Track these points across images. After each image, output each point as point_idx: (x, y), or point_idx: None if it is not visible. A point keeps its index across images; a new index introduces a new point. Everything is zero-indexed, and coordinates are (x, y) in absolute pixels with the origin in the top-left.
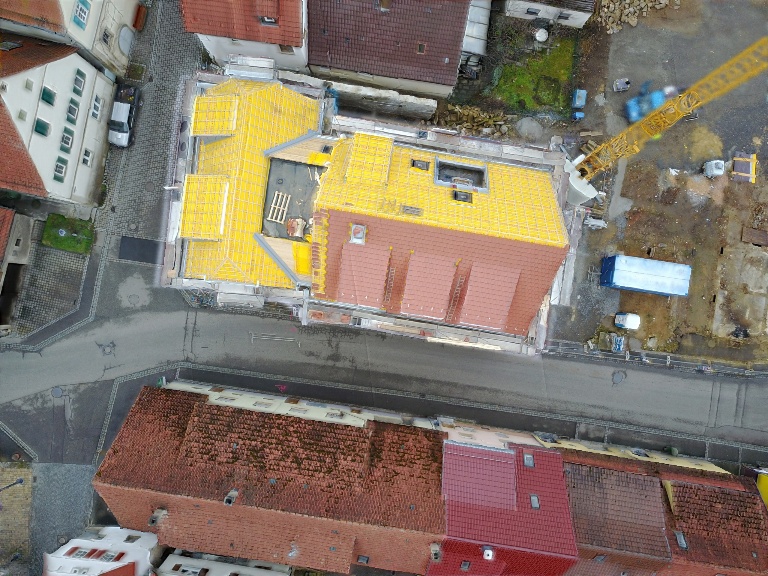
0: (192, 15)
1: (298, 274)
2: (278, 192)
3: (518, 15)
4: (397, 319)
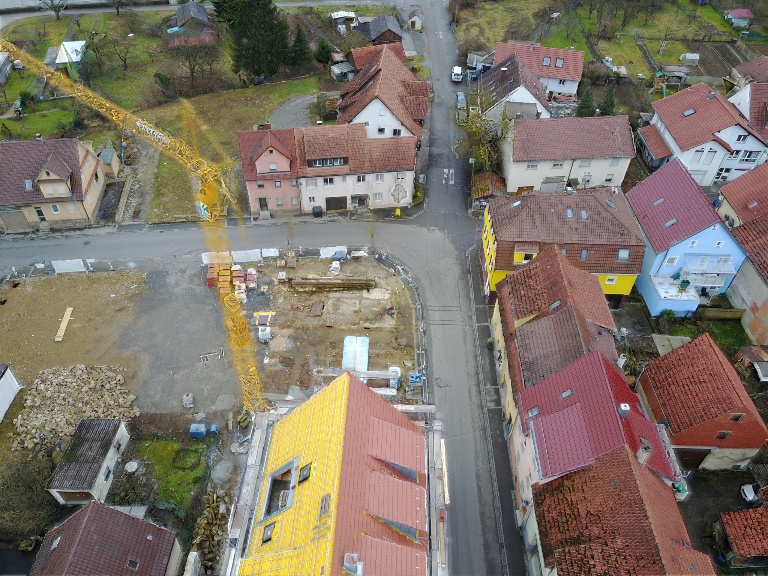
0: None
1: None
2: None
3: (105, 491)
4: (432, 548)
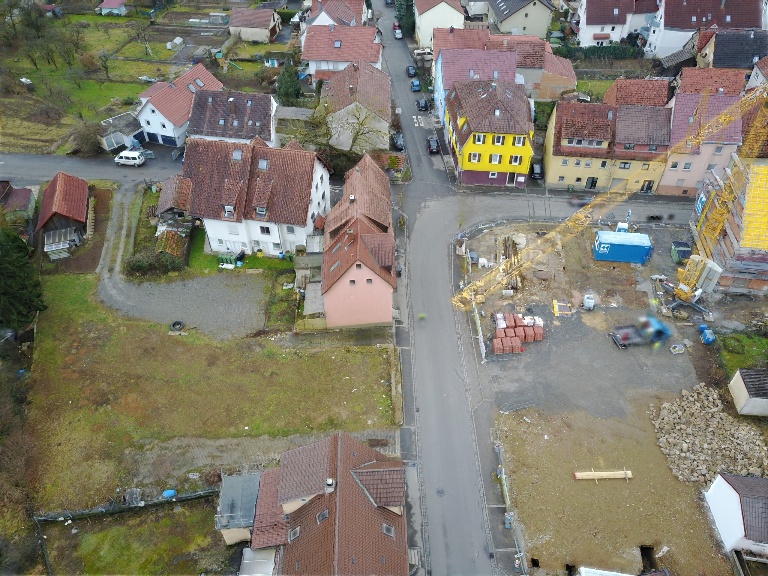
0: None
1: None
2: None
3: None
4: None
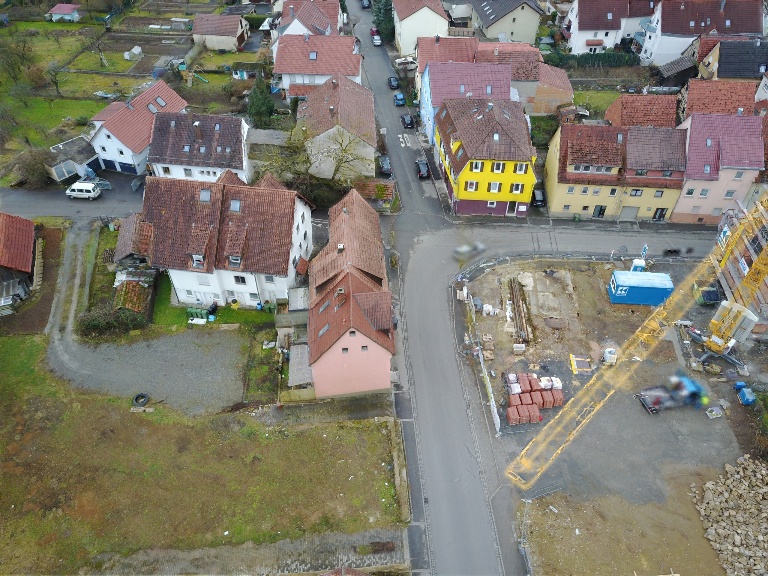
0: None
1: None
2: None
3: None
4: None
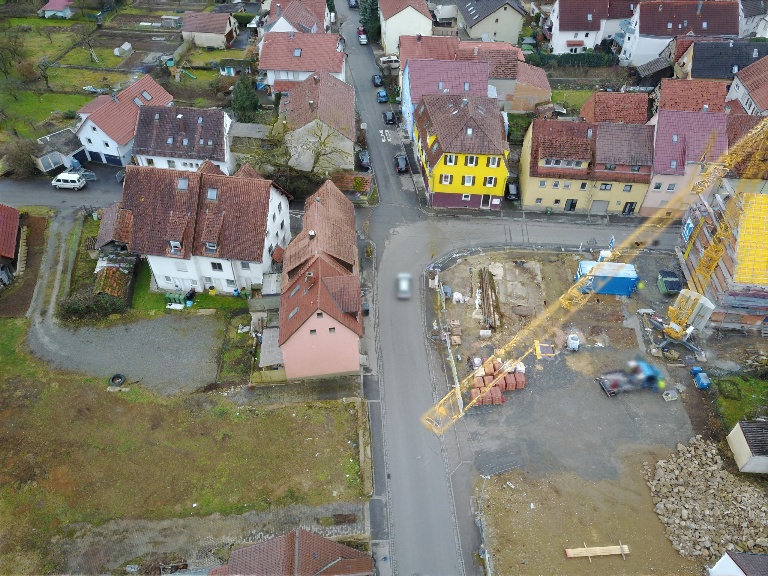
0: None
1: None
2: None
3: None
4: None
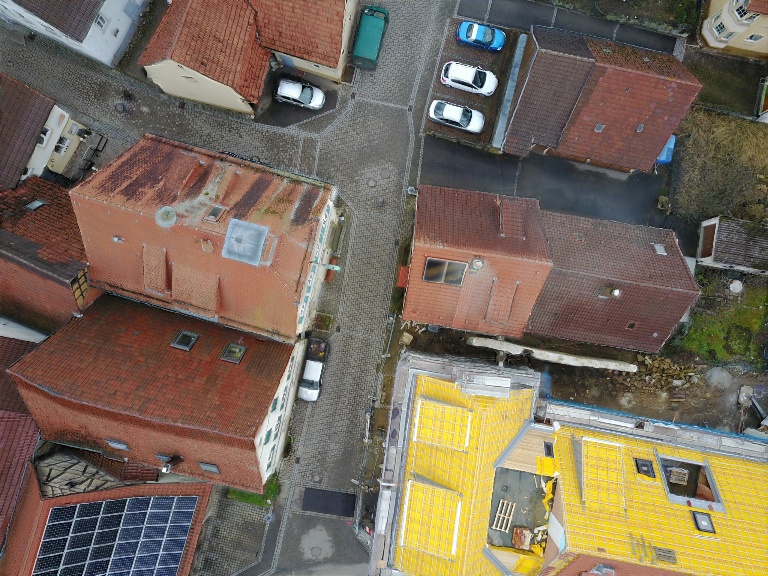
0: (412, 309)
1: (513, 572)
2: (503, 500)
3: None
4: None
